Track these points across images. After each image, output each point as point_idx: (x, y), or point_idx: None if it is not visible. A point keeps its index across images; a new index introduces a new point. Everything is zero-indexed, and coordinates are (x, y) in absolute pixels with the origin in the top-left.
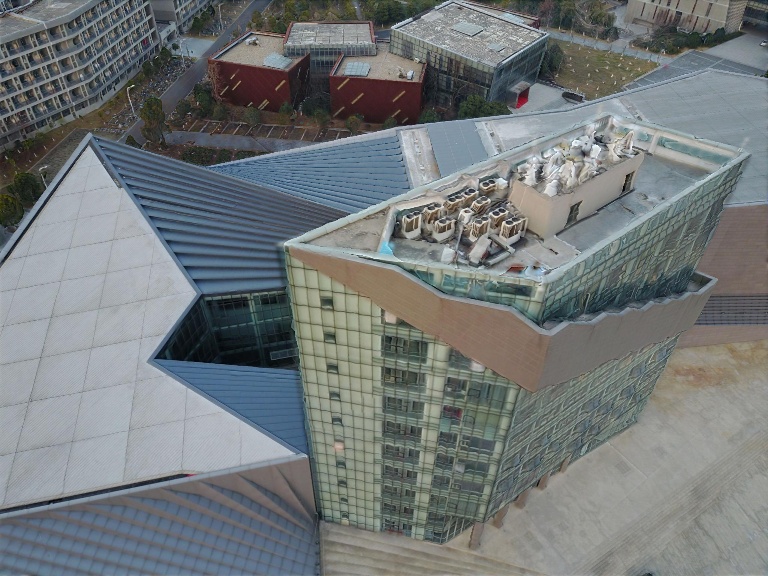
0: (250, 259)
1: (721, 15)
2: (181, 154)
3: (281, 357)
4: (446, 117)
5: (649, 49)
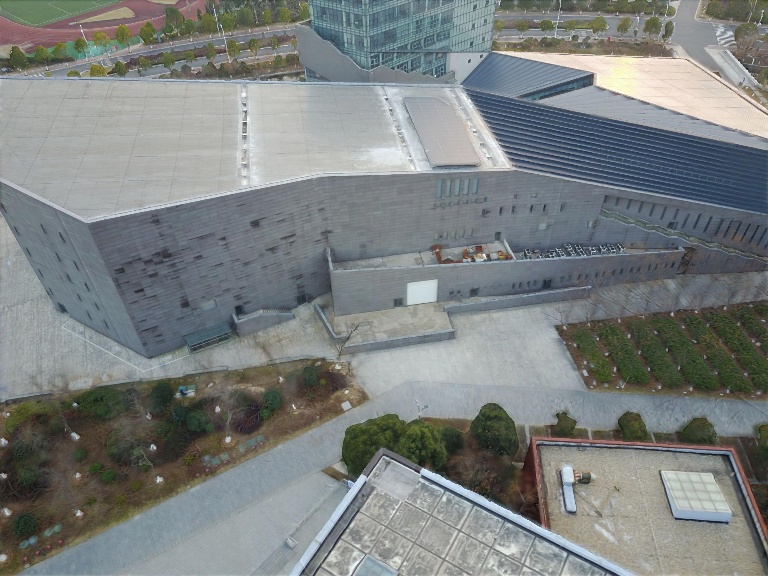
0: None
1: None
2: None
3: None
4: (469, 450)
5: None
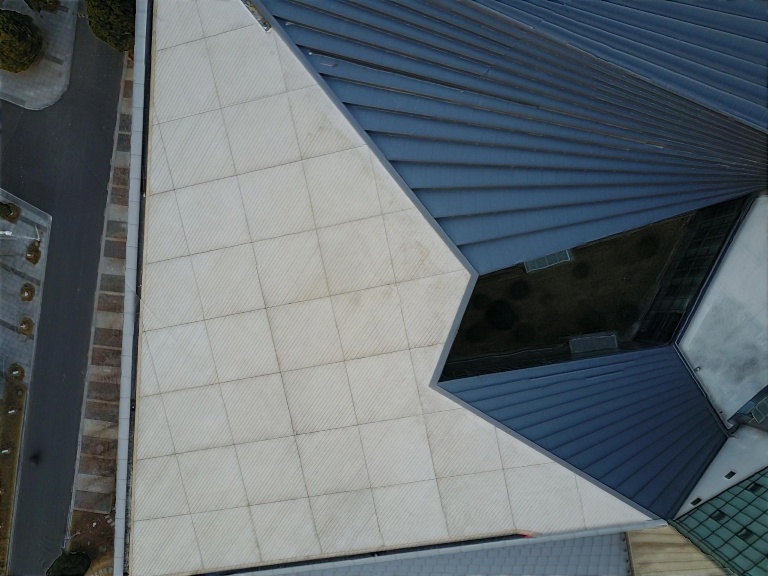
0: (529, 189)
1: None
2: None
3: (539, 267)
4: None
5: None
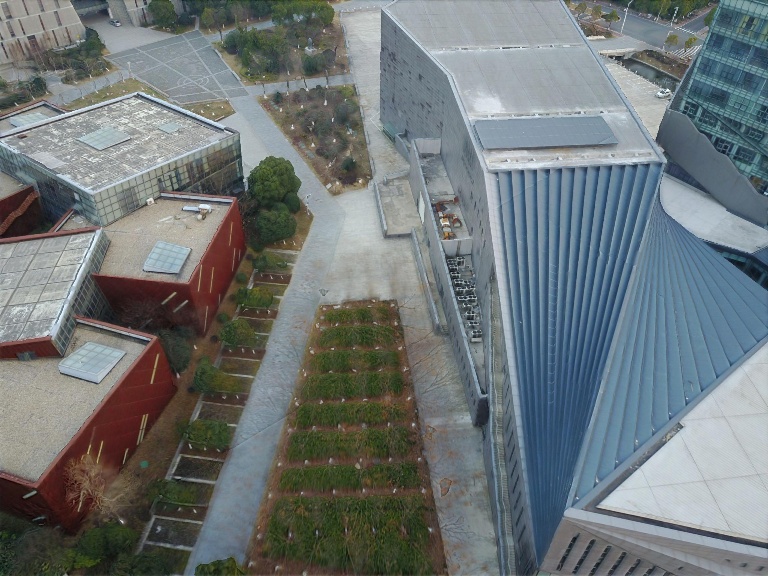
0: None
1: (73, 17)
2: (285, 561)
3: None
4: (264, 210)
5: (92, 75)
